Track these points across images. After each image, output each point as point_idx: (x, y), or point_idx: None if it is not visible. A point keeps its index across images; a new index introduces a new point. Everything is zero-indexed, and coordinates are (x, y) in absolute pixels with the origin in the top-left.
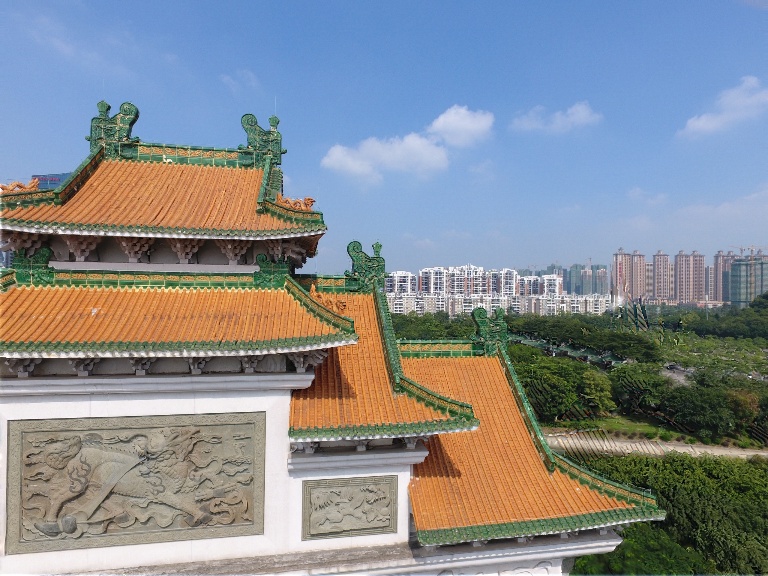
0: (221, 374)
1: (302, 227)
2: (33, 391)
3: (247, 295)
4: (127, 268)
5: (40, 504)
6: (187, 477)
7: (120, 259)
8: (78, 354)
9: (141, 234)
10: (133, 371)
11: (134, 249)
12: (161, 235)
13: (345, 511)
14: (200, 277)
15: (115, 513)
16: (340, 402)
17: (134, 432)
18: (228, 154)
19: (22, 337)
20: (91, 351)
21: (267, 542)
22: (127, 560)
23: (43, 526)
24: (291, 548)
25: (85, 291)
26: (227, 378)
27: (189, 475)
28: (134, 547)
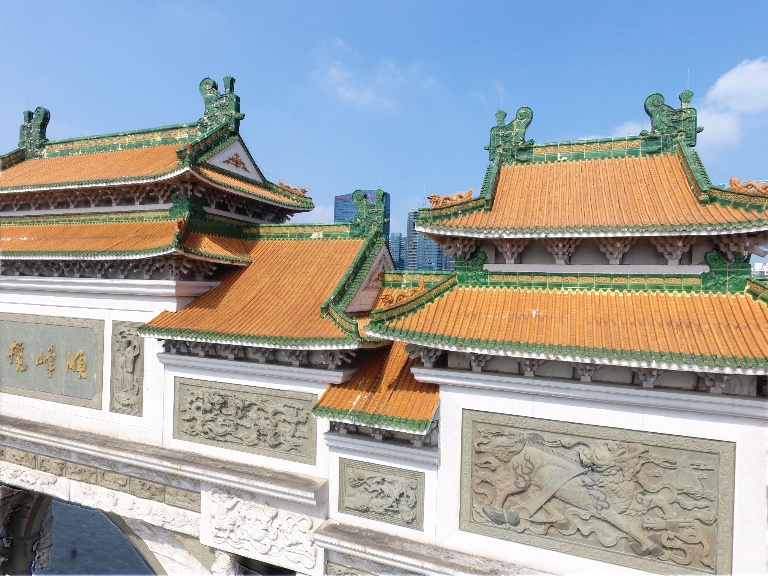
0: (680, 391)
1: None
2: (487, 385)
3: (696, 300)
4: (555, 270)
5: (487, 491)
6: (633, 499)
7: (538, 261)
8: (540, 355)
9: (582, 234)
10: (569, 375)
11: (562, 250)
12: (604, 234)
13: None
14: (634, 279)
15: (557, 518)
16: None
17: (575, 439)
18: (629, 143)
19: (483, 335)
20: (553, 353)
21: None
22: (568, 569)
23: (490, 512)
24: None
25: (517, 292)
26: (691, 397)
27: (636, 497)
28: (575, 558)
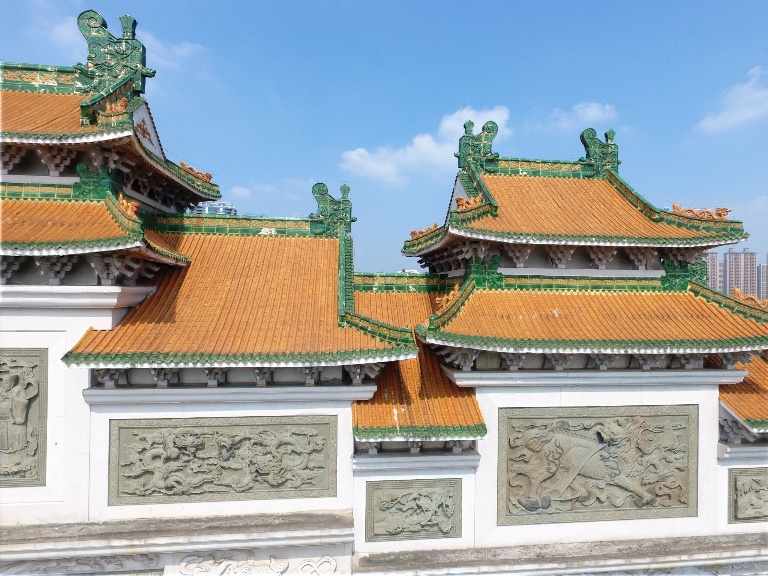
0: None
1: (720, 235)
2: (526, 382)
3: None
4: (558, 273)
5: (522, 482)
6: (635, 462)
7: (533, 265)
8: (586, 350)
9: (594, 243)
10: (581, 366)
11: None
12: (610, 244)
13: (765, 498)
14: (618, 281)
15: (581, 492)
16: (761, 397)
17: (593, 421)
18: (573, 166)
19: (529, 335)
20: (597, 348)
21: (701, 524)
22: (590, 535)
23: (525, 502)
24: (719, 530)
25: (531, 294)
26: (678, 373)
27: (637, 460)
28: (595, 523)
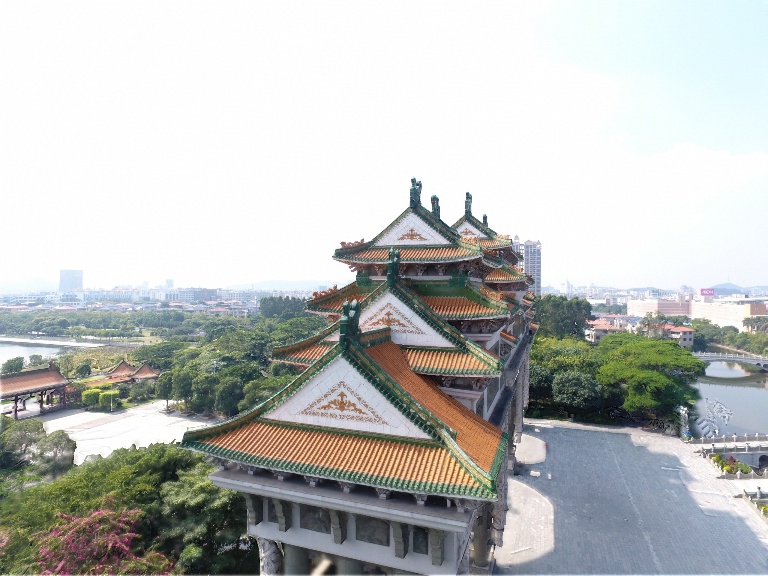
0: None
1: None
2: None
3: None
4: None
5: None
6: None
7: None
8: None
9: None
10: None
11: None
12: None
13: None
14: None
15: None
16: None
17: None
18: None
19: None
20: None
21: None
22: None
23: None
24: None
25: None
26: None
27: None
28: None
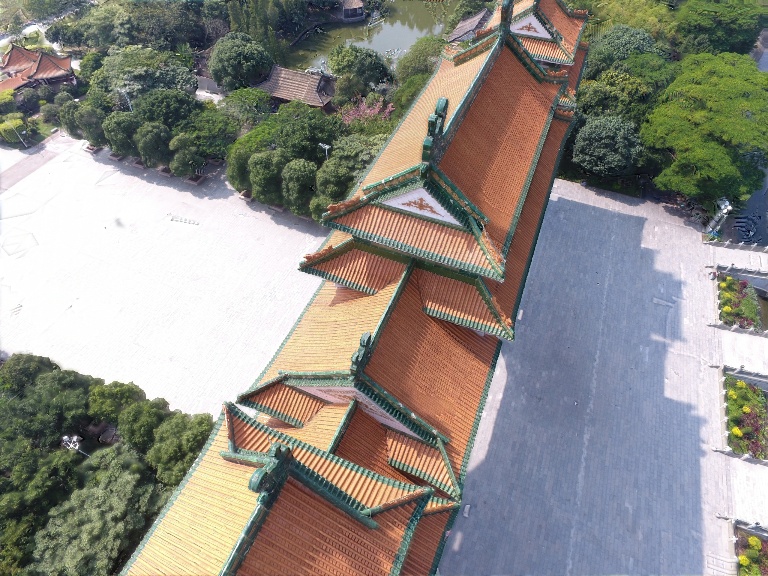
0: None
1: None
2: None
3: None
4: None
5: None
6: None
7: None
8: None
9: None
10: None
11: None
12: None
13: None
14: None
15: None
16: None
17: None
18: None
19: None
20: None
21: None
22: None
23: None
24: None
25: None
26: None
27: None
28: None
